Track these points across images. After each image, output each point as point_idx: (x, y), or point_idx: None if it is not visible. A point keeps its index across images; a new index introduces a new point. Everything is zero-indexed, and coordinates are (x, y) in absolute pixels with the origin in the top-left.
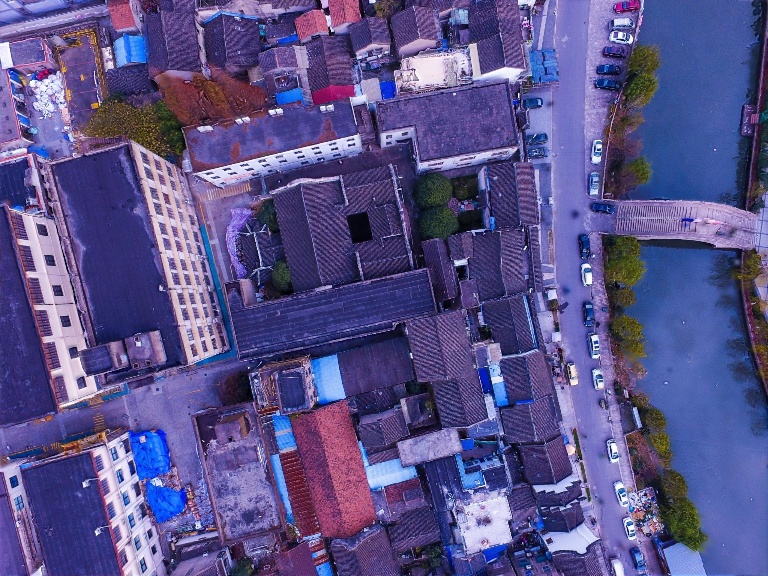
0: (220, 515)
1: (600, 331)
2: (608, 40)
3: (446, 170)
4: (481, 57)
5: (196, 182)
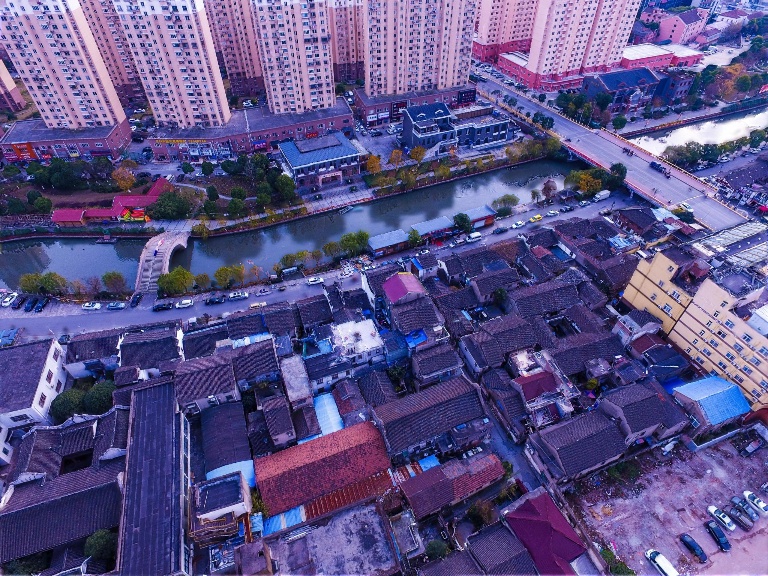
0: None
1: None
2: (7, 307)
3: None
4: None
5: None
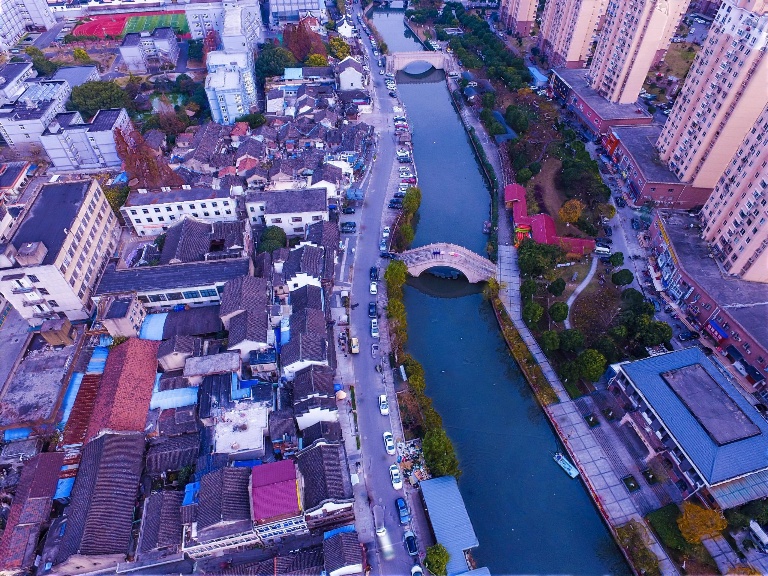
0: (1, 407)
1: (381, 321)
2: (398, 192)
3: (288, 235)
4: (313, 179)
5: (125, 226)
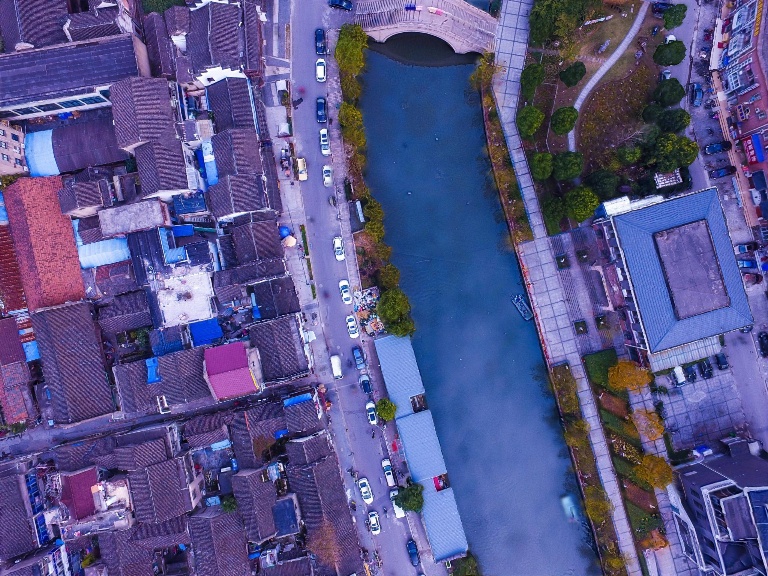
0: None
1: (333, 128)
2: None
3: None
4: None
5: None
